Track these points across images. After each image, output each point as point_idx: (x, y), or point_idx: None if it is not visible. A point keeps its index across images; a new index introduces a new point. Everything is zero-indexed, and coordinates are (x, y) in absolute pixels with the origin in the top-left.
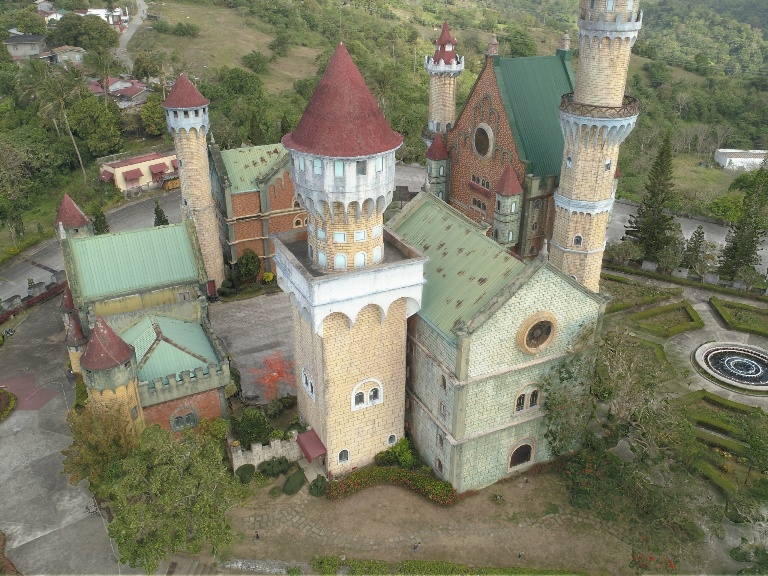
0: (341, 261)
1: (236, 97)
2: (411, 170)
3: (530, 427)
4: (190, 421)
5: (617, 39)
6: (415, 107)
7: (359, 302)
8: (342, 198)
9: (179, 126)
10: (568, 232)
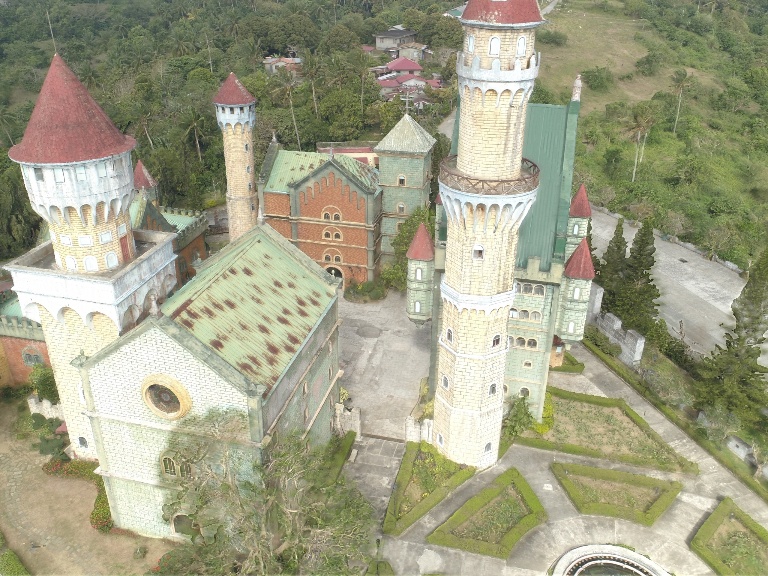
0: (59, 259)
1: None
2: (608, 220)
3: (190, 499)
4: (39, 362)
5: (478, 90)
6: (758, 155)
7: (56, 301)
8: (34, 199)
9: (219, 120)
10: (443, 321)
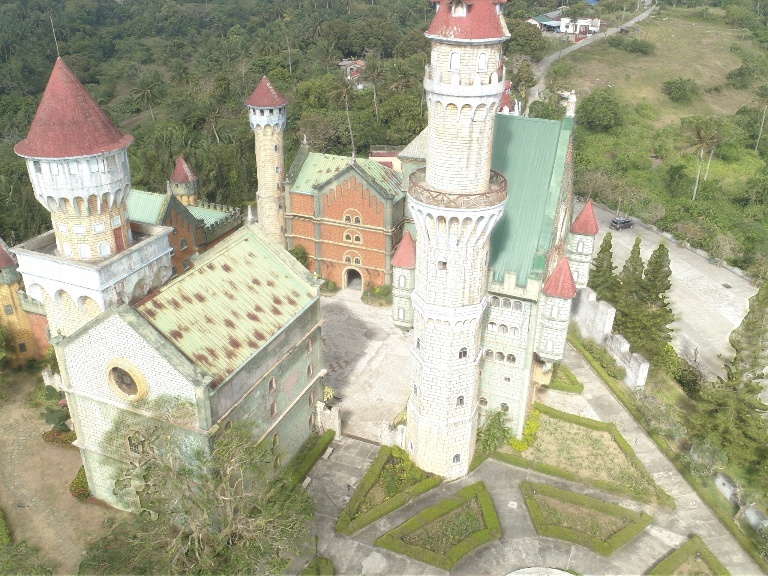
0: None
1: (554, 118)
2: (654, 239)
3: None
4: None
5: (440, 104)
6: None
7: (53, 284)
8: None
9: (251, 121)
10: None
